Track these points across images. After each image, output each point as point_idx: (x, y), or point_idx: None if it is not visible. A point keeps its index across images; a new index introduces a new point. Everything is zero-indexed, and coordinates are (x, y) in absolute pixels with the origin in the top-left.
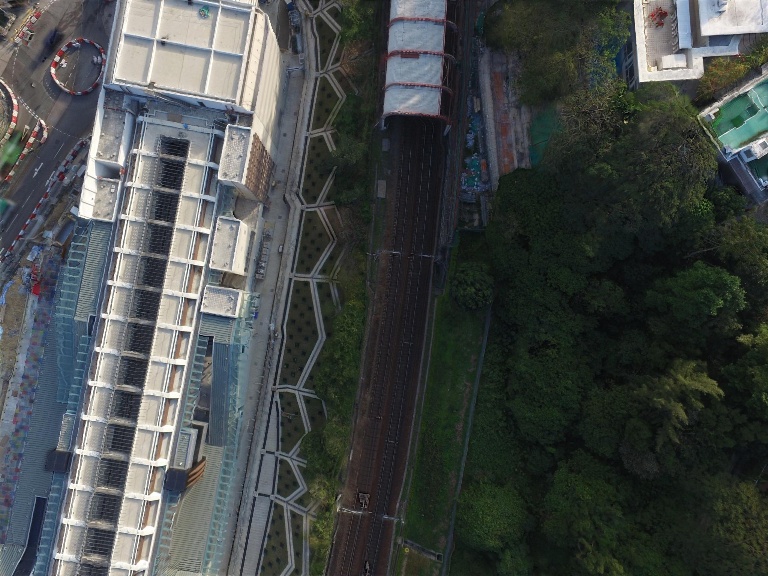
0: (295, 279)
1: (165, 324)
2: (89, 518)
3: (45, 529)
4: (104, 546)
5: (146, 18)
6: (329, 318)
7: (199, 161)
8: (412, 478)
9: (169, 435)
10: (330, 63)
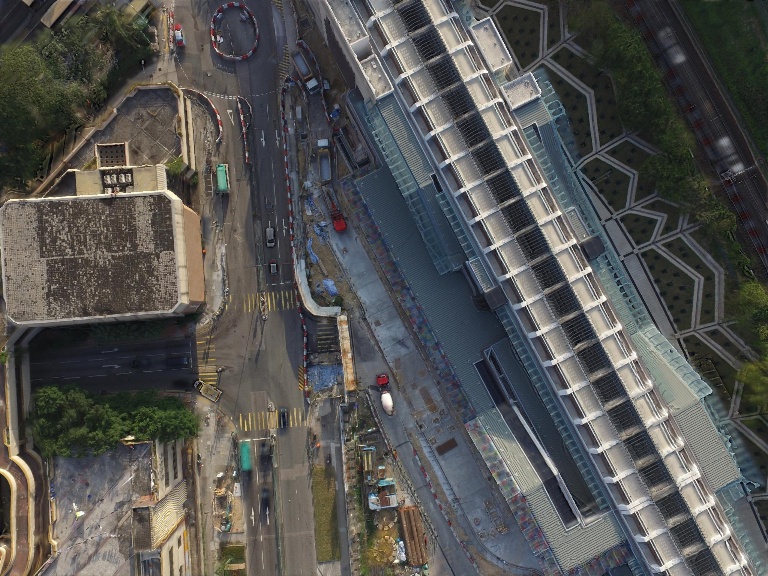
0: None
1: (498, 133)
2: (556, 317)
3: (522, 357)
4: (585, 326)
5: None
6: (586, 72)
7: None
8: (751, 135)
9: (560, 220)
10: None
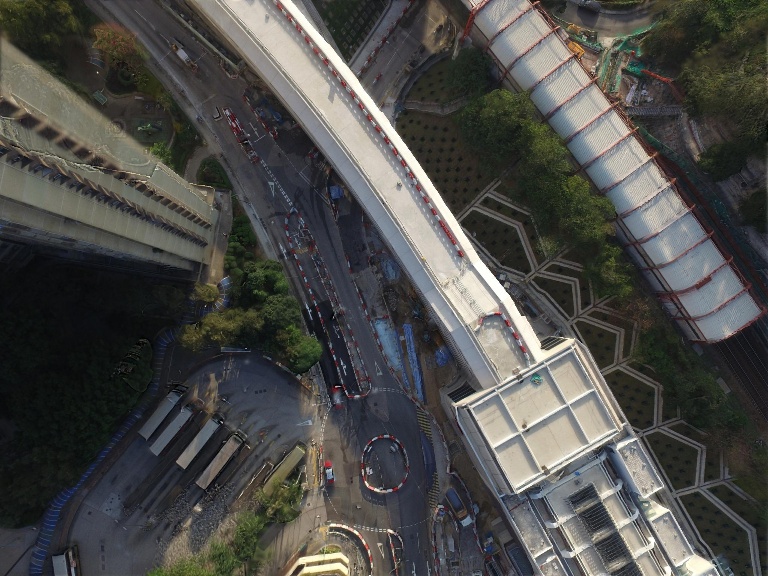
0: (679, 496)
1: None
2: None
3: None
4: None
5: (497, 420)
6: (747, 512)
7: (609, 493)
8: None
9: None
10: (579, 309)
